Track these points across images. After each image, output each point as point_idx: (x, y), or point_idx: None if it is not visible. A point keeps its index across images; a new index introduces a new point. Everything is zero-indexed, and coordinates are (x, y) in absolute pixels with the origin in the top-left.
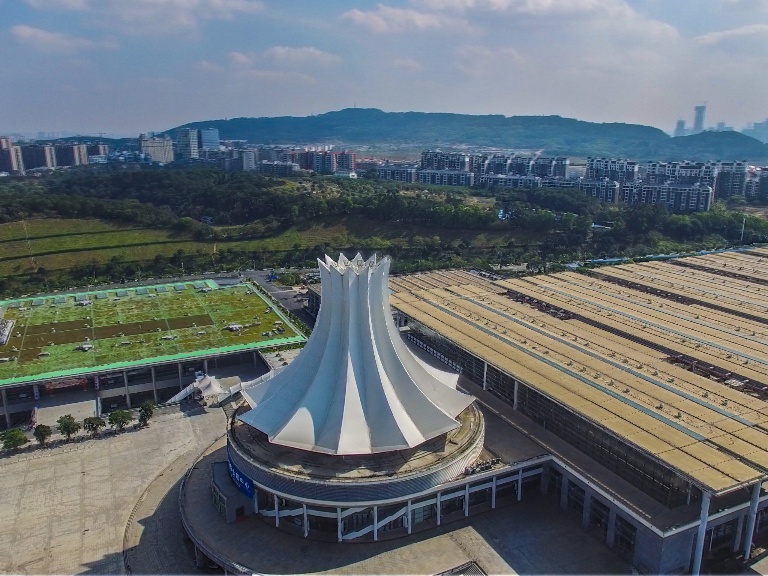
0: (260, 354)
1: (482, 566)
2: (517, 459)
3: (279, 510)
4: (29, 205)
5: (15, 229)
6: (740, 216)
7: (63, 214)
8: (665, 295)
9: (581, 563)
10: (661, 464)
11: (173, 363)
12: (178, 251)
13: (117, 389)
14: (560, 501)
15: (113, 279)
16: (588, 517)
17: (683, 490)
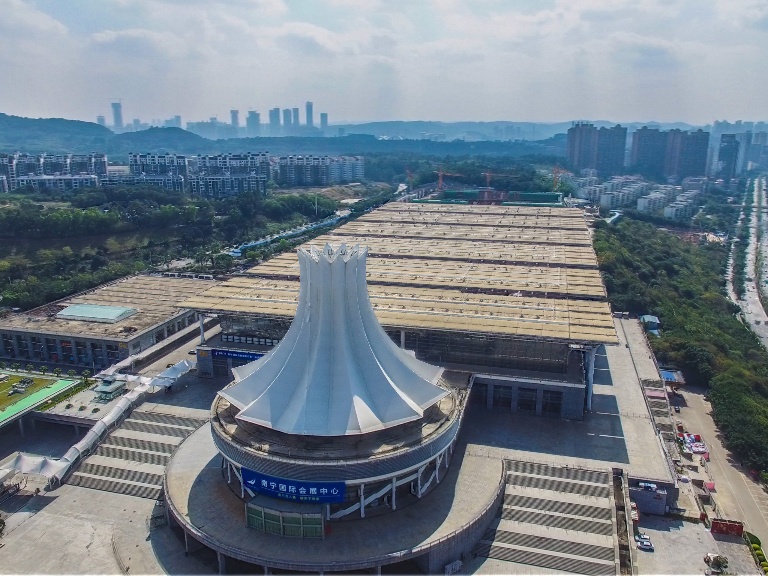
0: (42, 413)
1: (513, 458)
2: (463, 384)
3: (365, 500)
4: None
5: None
6: (306, 196)
7: None
8: (378, 256)
9: (544, 430)
10: (577, 342)
11: None
12: None
13: None
14: (487, 405)
15: None
16: (517, 404)
17: (576, 357)
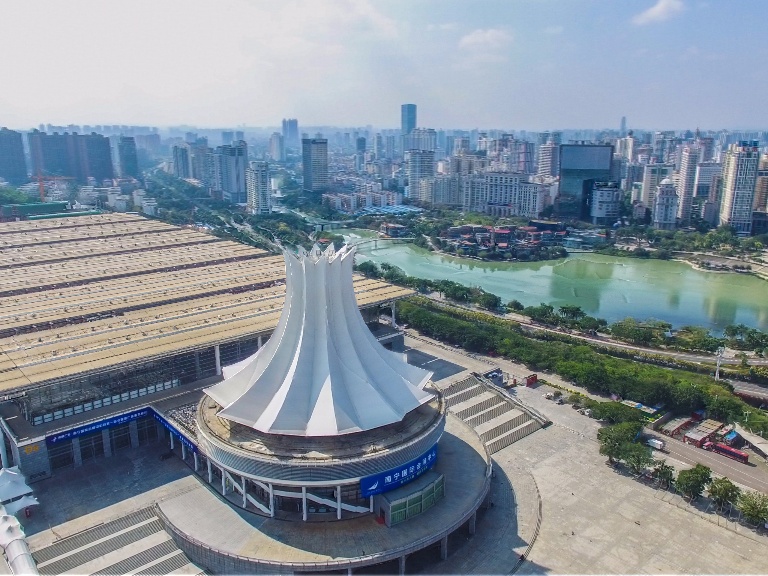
0: None
1: None
2: None
3: None
4: None
5: None
6: None
7: None
8: (55, 287)
9: None
10: None
11: None
12: None
13: None
14: None
15: None
16: None
17: None
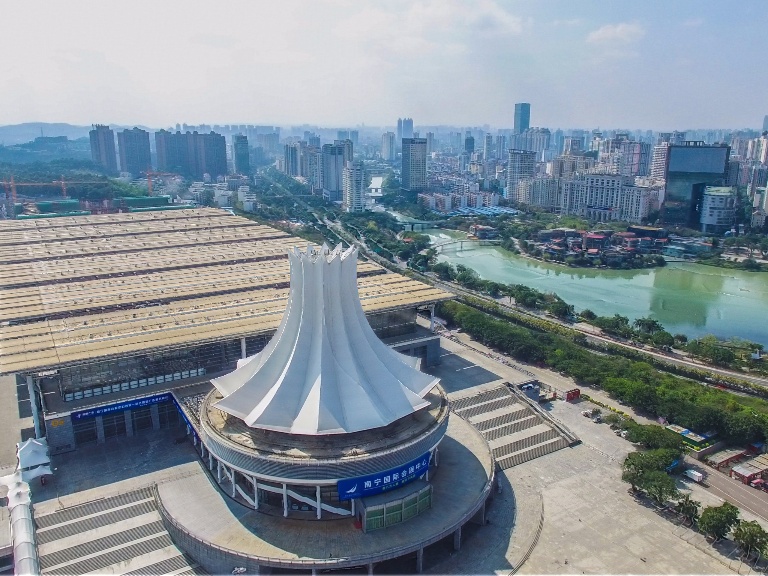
0: None
1: None
2: None
3: None
4: None
5: None
6: None
7: None
8: (122, 275)
9: None
10: None
11: None
12: None
13: None
14: None
15: None
16: None
17: None
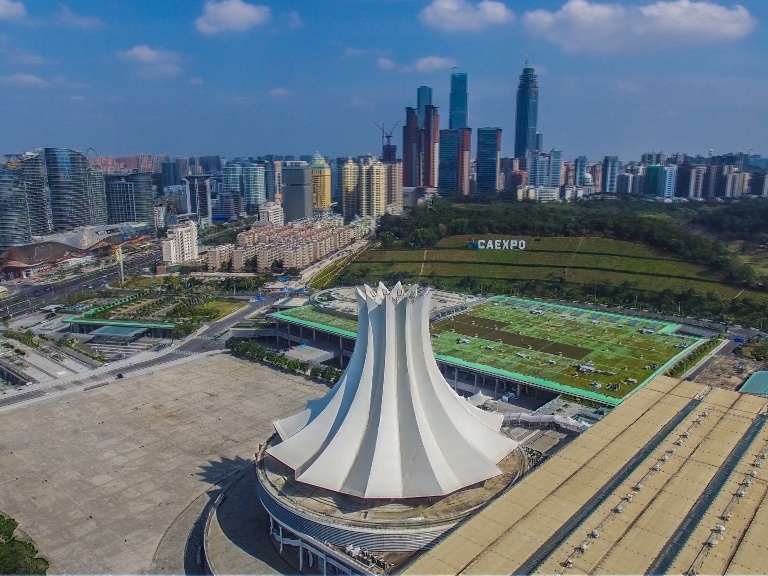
0: None
1: None
2: None
3: None
4: (596, 224)
5: (573, 243)
6: None
7: (617, 235)
8: None
9: None
10: None
11: (486, 374)
12: (689, 289)
13: (450, 380)
14: None
15: (612, 302)
16: None
17: None
